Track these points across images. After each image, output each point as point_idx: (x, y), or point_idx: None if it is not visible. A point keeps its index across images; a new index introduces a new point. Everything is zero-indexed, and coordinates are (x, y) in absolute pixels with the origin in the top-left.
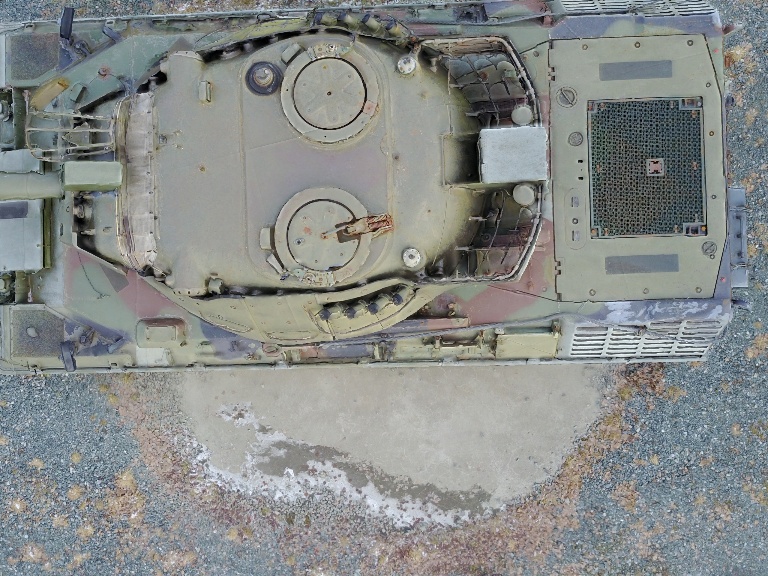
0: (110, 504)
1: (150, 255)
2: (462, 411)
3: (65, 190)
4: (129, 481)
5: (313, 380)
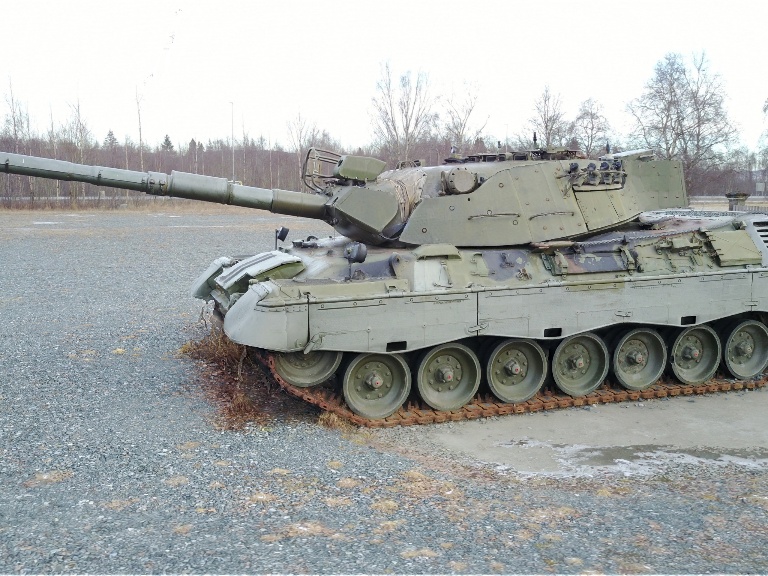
0: (406, 487)
1: (420, 181)
2: (749, 415)
3: (343, 168)
4: (421, 474)
5: (579, 420)
